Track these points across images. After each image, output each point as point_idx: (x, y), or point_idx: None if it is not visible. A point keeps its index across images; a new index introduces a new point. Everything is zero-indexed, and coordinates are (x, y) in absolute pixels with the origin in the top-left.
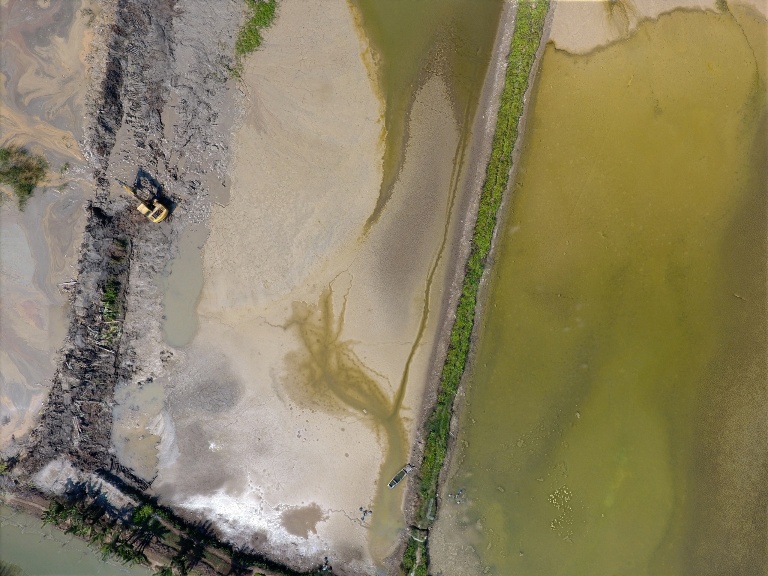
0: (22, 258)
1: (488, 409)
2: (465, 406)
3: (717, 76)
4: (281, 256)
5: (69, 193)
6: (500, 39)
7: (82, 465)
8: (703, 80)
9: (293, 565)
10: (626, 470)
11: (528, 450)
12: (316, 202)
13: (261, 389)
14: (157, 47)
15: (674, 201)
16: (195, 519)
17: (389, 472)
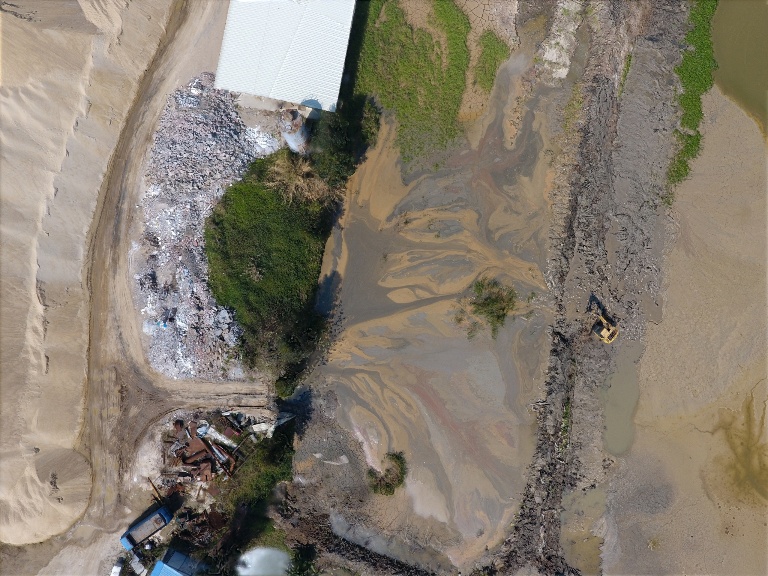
0: (494, 382)
1: None
2: None
3: None
4: (708, 367)
5: (534, 320)
6: None
7: (546, 570)
8: None
9: None
10: None
11: None
12: (738, 317)
13: (693, 490)
14: (605, 181)
15: None
16: None
17: None
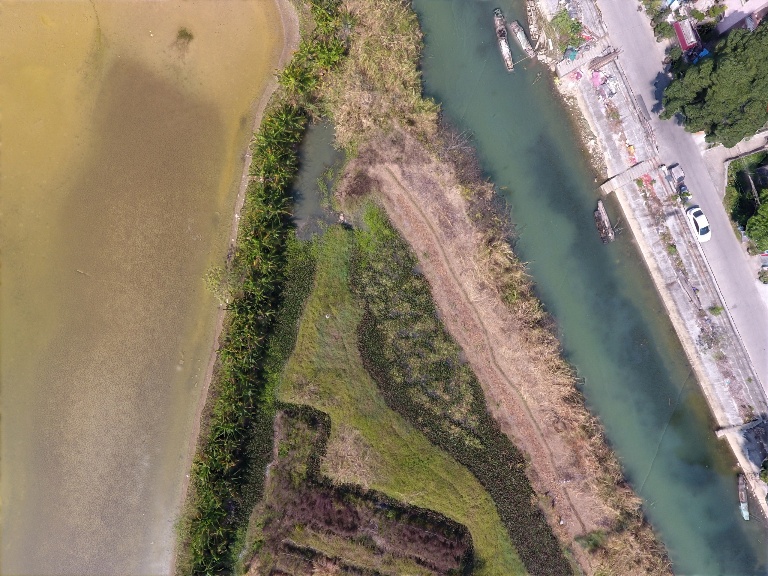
0: None
1: None
2: None
3: (53, 31)
4: None
5: None
6: None
7: None
8: (37, 36)
9: None
10: None
11: None
12: None
13: None
14: None
15: (6, 168)
16: None
17: None
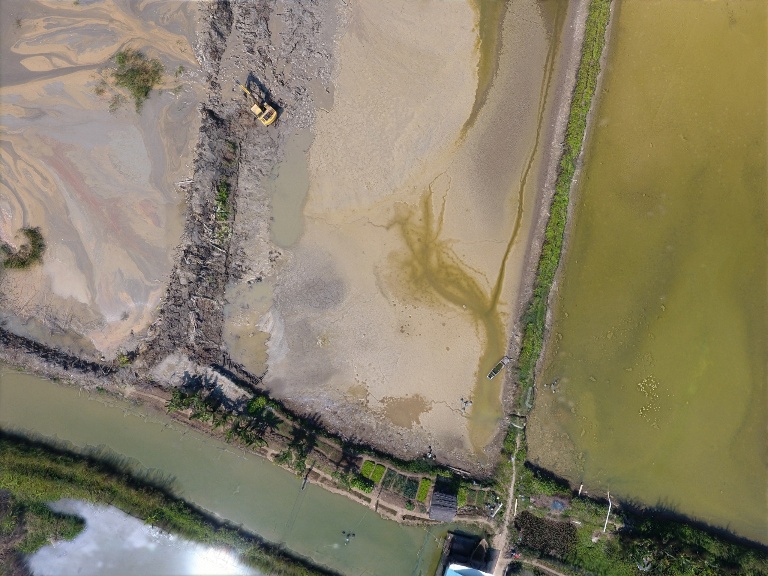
0: (139, 158)
1: (580, 303)
2: (558, 300)
3: None
4: (383, 159)
5: (183, 96)
6: None
7: (198, 359)
8: None
9: (399, 454)
10: (708, 359)
11: (617, 341)
12: (415, 107)
13: (366, 286)
14: None
15: (748, 106)
16: (305, 412)
17: (488, 364)
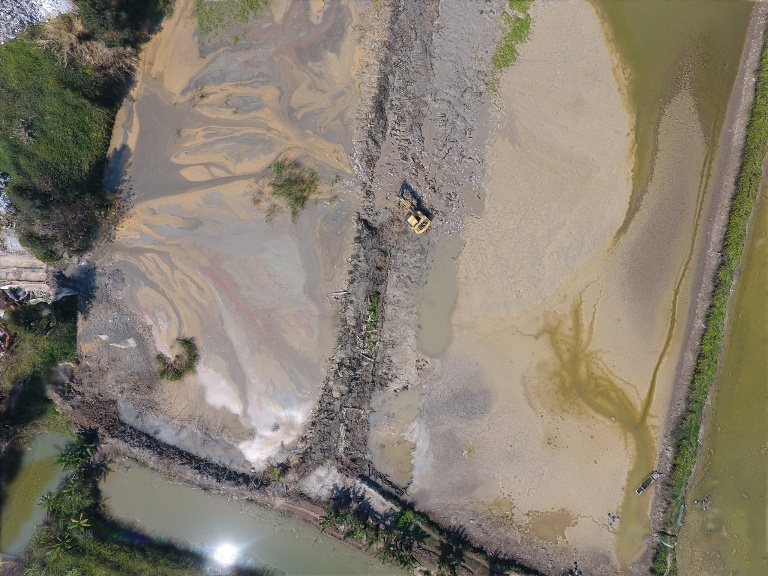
0: (293, 268)
1: (733, 417)
2: (711, 414)
3: None
4: (533, 267)
5: (338, 205)
6: (747, 54)
7: (346, 471)
8: None
9: (544, 570)
10: None
11: None
12: (568, 214)
13: (513, 397)
14: (421, 62)
15: None
16: (449, 524)
17: (636, 479)
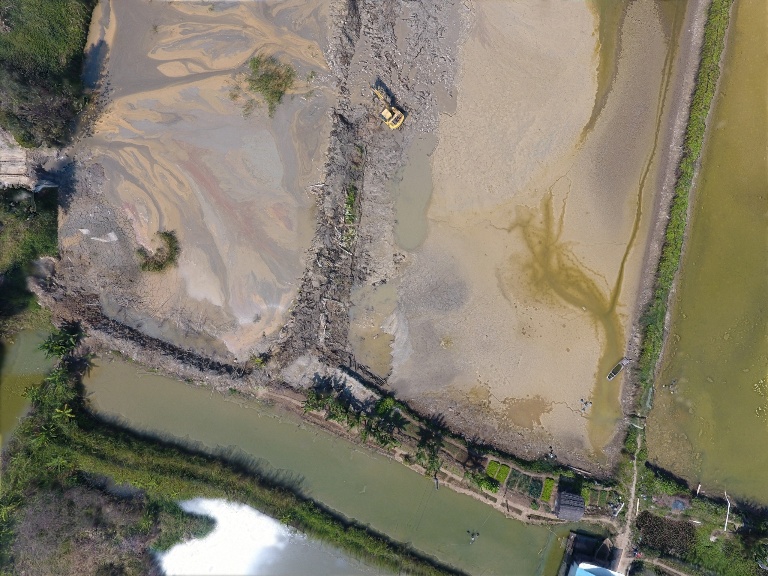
0: (271, 162)
1: (697, 305)
2: (676, 302)
3: None
4: (505, 162)
5: (314, 100)
6: None
7: (328, 360)
8: None
9: (521, 454)
10: None
11: (734, 343)
12: (536, 111)
13: (488, 289)
14: None
15: None
16: (429, 412)
17: (607, 365)
